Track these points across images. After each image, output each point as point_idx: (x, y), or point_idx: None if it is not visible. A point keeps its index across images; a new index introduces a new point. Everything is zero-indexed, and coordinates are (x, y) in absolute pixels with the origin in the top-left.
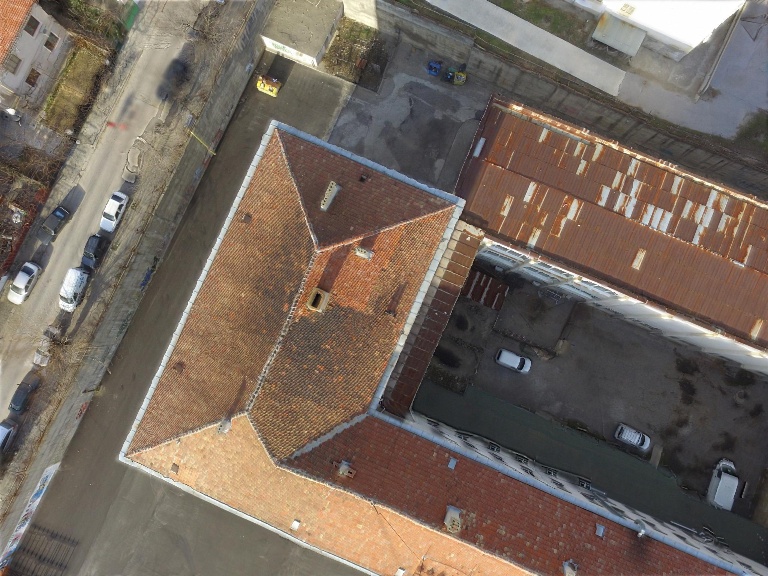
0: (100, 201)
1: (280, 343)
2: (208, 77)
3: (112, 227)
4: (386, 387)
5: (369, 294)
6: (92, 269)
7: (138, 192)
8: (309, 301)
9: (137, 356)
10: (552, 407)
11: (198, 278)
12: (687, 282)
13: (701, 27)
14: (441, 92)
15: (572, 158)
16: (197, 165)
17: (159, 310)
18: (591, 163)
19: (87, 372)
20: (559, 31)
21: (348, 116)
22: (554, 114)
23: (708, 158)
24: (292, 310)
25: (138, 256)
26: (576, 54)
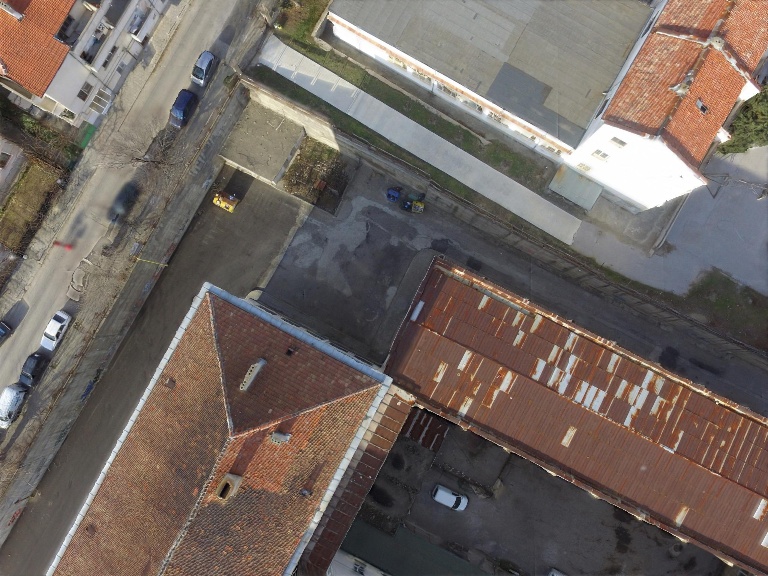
0: (43, 317)
1: (187, 528)
2: (159, 201)
3: (52, 346)
4: (304, 549)
5: (285, 473)
6: (30, 387)
7: (81, 311)
8: (218, 490)
9: (75, 464)
10: (486, 546)
11: (141, 390)
12: (616, 464)
13: (654, 196)
14: (399, 218)
15: (510, 328)
16: (146, 280)
17: (100, 419)
18: (529, 334)
19: (19, 485)
20: (517, 175)
21: (303, 236)
22: (510, 250)
23: (659, 312)
24: (201, 496)
25: (77, 375)
26: (533, 200)
